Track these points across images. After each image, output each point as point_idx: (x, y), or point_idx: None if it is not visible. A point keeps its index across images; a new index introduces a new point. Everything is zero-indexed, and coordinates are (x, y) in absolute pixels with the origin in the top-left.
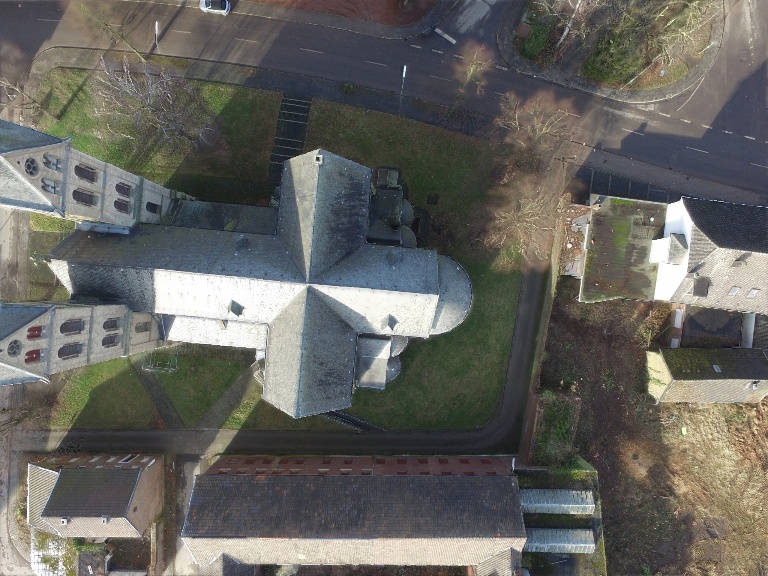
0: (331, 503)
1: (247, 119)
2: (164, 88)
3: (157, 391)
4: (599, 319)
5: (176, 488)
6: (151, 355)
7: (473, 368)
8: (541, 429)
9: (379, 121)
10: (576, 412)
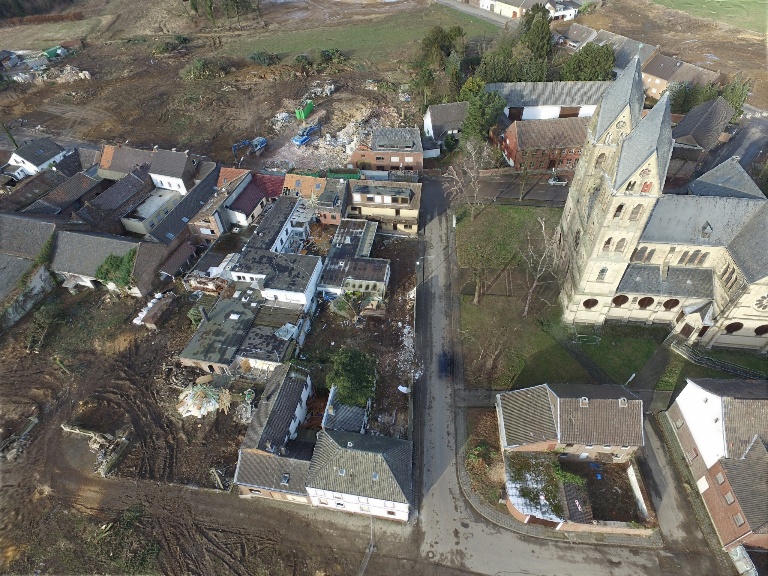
0: None
1: None
2: None
3: (585, 360)
4: None
5: None
6: (573, 334)
7: None
8: None
9: None
10: None
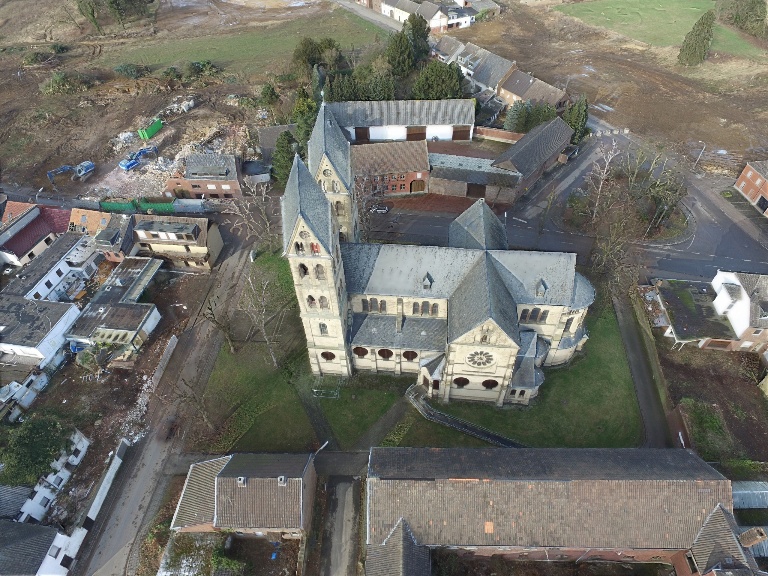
0: (512, 462)
1: None
2: None
3: (318, 417)
4: (701, 364)
5: (326, 512)
6: (317, 387)
7: (606, 398)
8: (694, 430)
9: None
10: (720, 417)
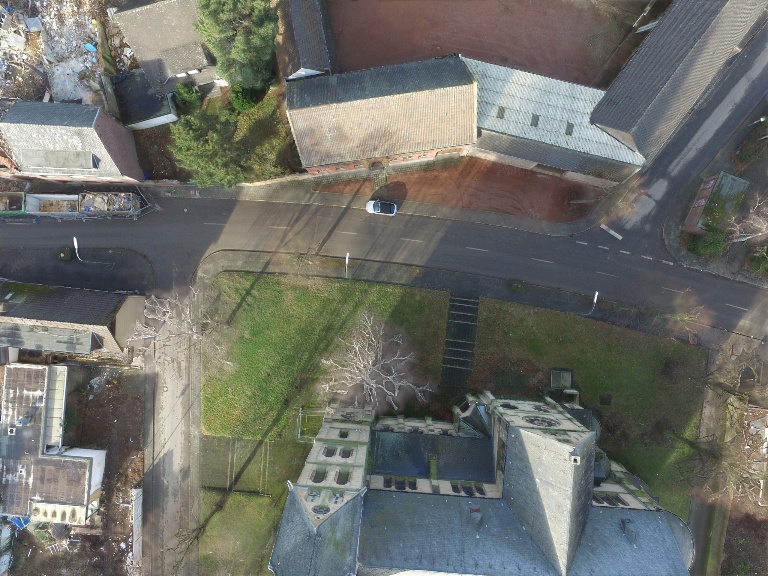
0: None
1: (417, 321)
2: (368, 332)
3: None
4: None
5: None
6: None
7: None
8: None
9: (548, 319)
10: None
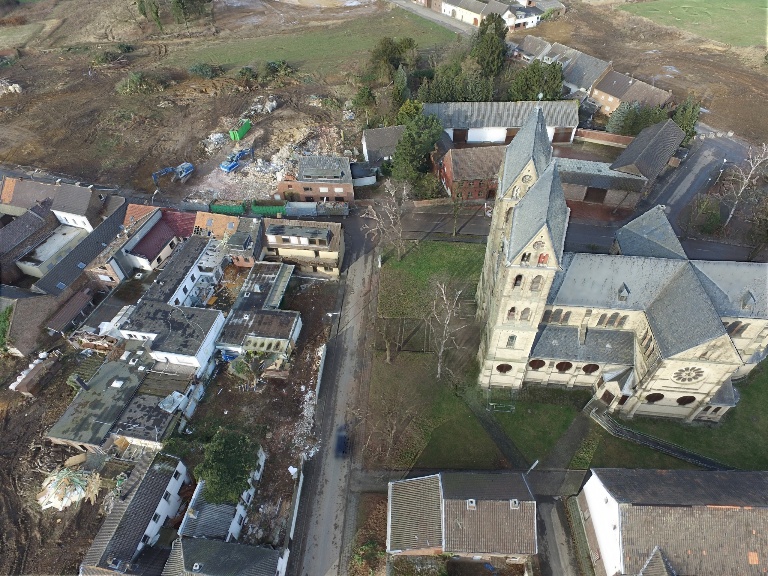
0: (756, 487)
1: None
2: None
3: (496, 432)
4: None
5: None
6: (487, 400)
7: None
8: None
9: None
10: None
